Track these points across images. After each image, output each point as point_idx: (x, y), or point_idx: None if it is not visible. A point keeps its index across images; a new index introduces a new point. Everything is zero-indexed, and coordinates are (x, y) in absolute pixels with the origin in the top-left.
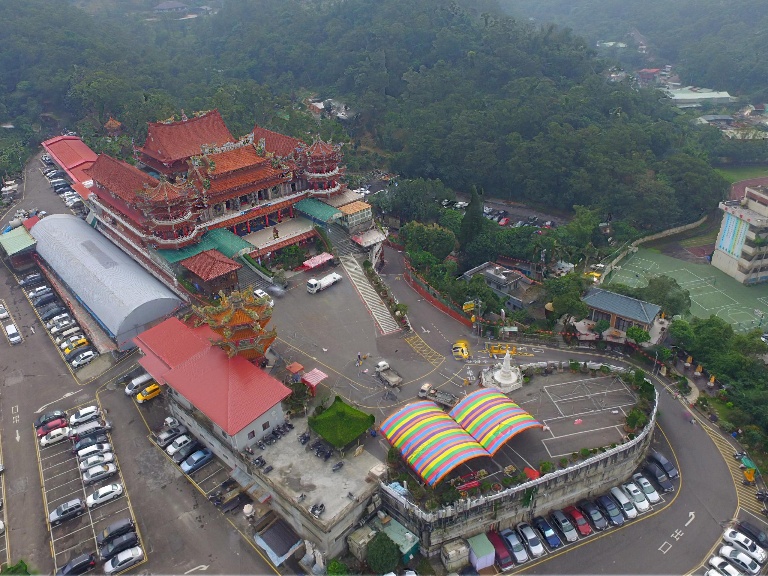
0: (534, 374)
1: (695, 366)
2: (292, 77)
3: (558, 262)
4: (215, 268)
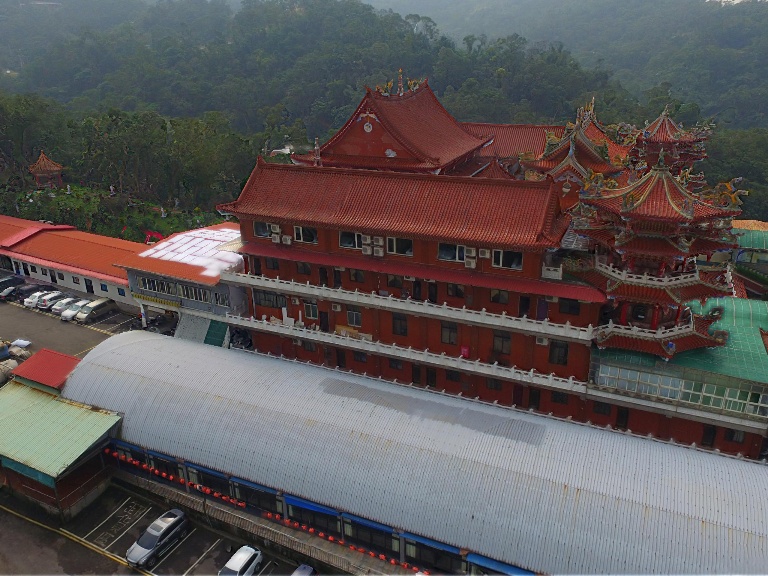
0: None
1: None
2: (235, 117)
3: None
4: None
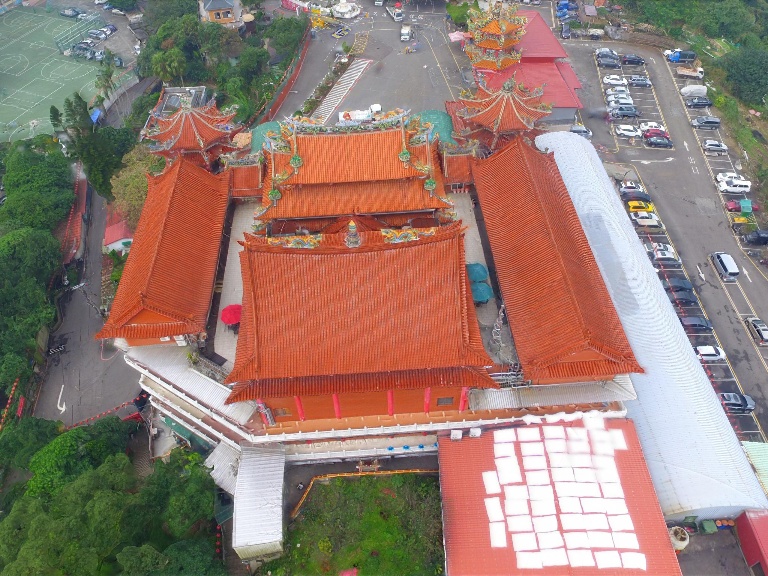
0: (325, 7)
1: None
2: None
3: None
4: None
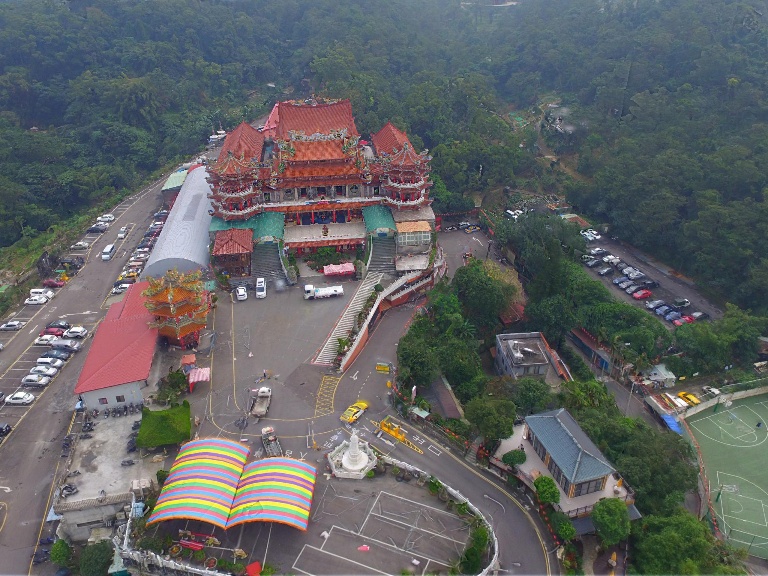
0: (389, 472)
1: (622, 570)
2: (537, 78)
3: (657, 365)
4: (227, 246)
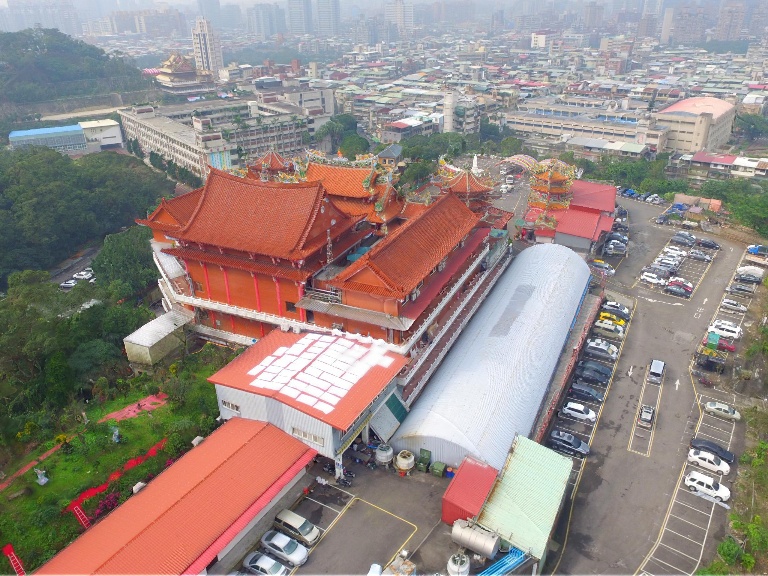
0: None
1: None
2: None
3: None
4: None
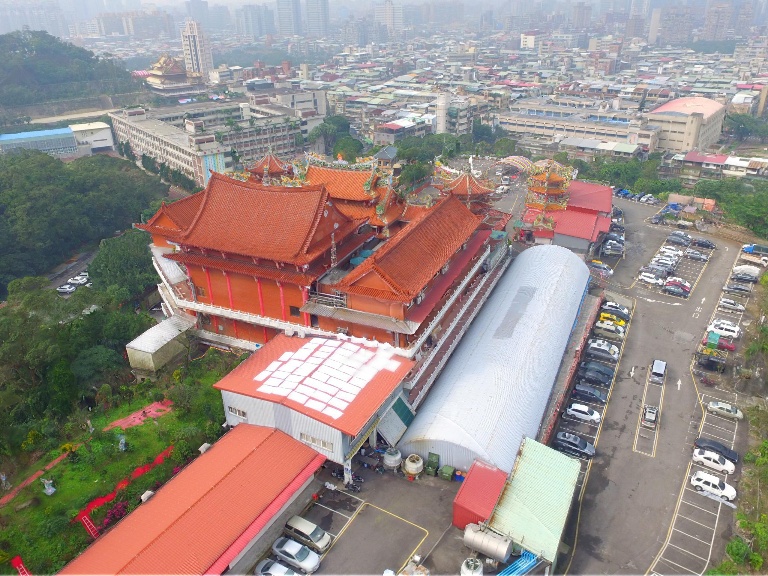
0: None
1: None
2: None
3: None
4: None
